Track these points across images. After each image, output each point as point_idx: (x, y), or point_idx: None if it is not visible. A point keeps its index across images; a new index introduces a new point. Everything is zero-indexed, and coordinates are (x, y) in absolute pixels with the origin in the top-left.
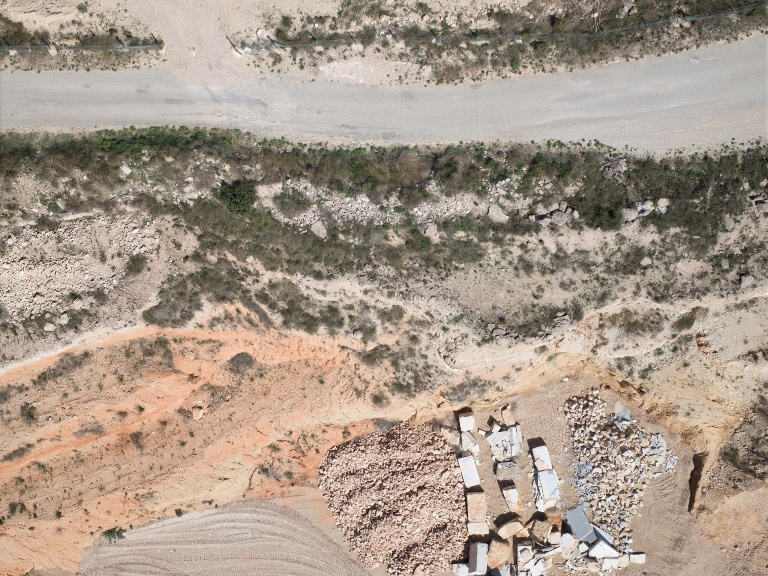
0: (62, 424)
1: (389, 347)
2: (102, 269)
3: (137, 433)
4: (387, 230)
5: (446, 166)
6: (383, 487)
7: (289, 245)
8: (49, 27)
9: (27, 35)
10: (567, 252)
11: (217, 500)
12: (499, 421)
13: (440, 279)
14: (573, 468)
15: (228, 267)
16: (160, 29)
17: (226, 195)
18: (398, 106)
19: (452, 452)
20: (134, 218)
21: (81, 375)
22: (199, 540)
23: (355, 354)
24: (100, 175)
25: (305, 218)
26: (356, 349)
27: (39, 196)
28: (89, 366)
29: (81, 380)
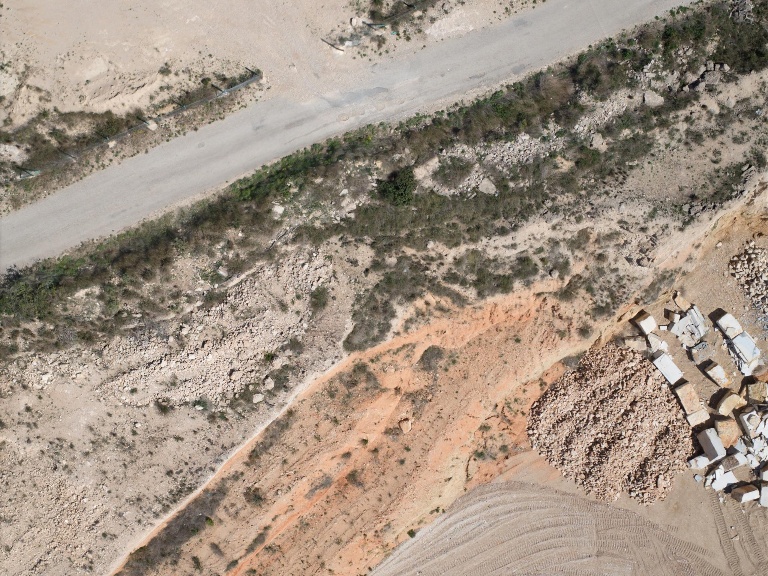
0: (293, 492)
1: (580, 275)
2: (287, 318)
3: (352, 473)
4: (555, 158)
5: (588, 73)
6: (598, 419)
7: (463, 215)
8: (139, 103)
9: (120, 120)
10: (729, 107)
11: (442, 505)
12: (674, 310)
13: (619, 184)
14: (761, 322)
15: (408, 263)
16: (252, 59)
17: (388, 191)
18: (516, 37)
19: (643, 359)
20: (299, 255)
21: (292, 436)
22: (440, 551)
23: (552, 296)
24: (256, 225)
25: (470, 182)
26: (552, 290)
27: (199, 273)
28: (297, 423)
29: (294, 440)
